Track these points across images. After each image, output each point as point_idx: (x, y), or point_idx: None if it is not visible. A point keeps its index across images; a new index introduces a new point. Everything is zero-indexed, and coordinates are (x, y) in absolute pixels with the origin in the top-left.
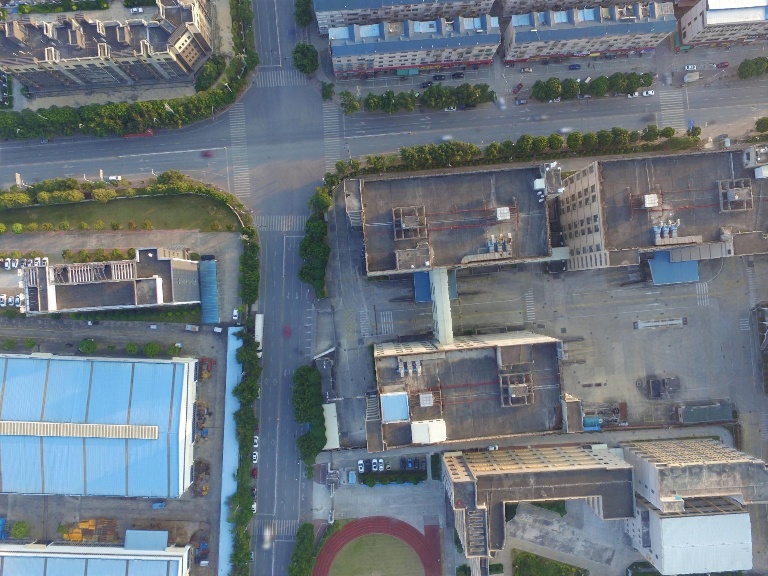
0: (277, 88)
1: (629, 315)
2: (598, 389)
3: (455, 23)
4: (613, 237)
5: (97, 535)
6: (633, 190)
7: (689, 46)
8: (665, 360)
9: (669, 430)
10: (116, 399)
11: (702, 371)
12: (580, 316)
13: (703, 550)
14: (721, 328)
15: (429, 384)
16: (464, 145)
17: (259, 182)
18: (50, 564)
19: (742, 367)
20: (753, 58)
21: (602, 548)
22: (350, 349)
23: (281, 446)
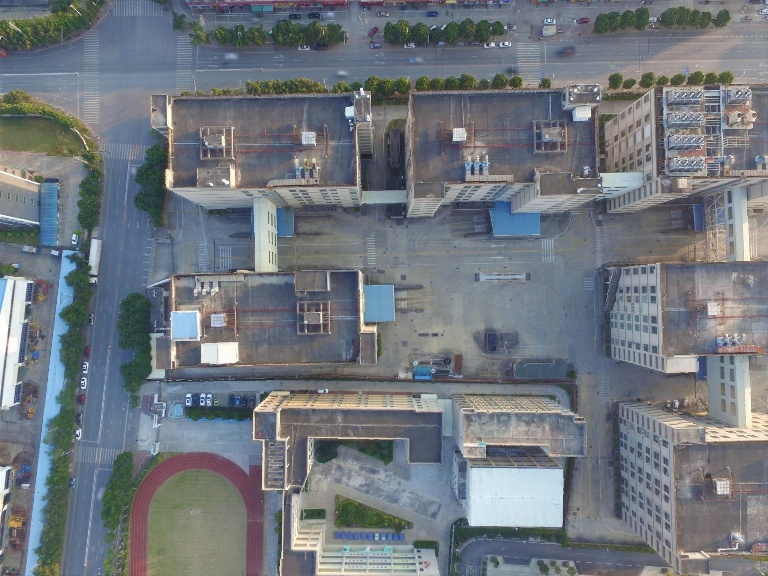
0: (133, 18)
1: (471, 266)
2: (434, 339)
3: None
4: (423, 171)
5: None
6: (447, 125)
7: None
8: (505, 314)
9: (505, 386)
10: None
11: (542, 328)
12: (421, 264)
13: (512, 503)
14: (565, 286)
15: (226, 306)
16: (309, 82)
17: (108, 109)
18: None
19: (584, 327)
20: (609, 13)
21: (428, 501)
22: None
23: (111, 374)
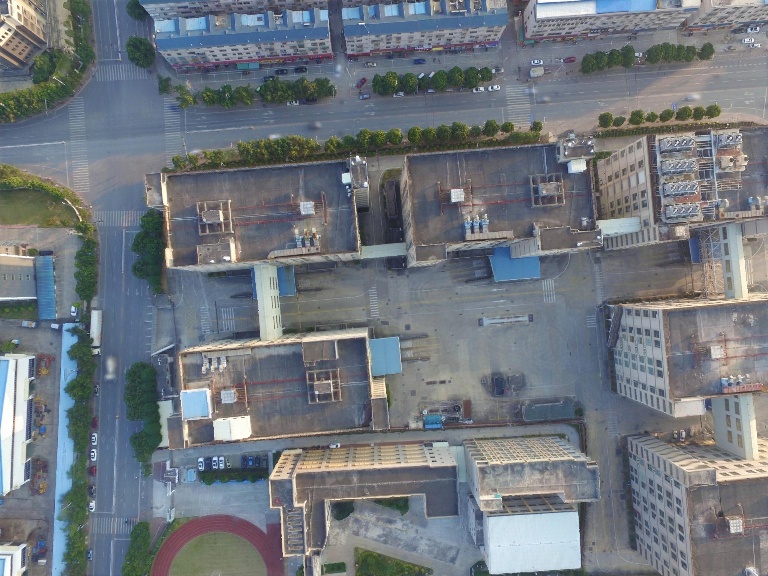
0: (117, 82)
1: (474, 312)
2: (442, 386)
3: (283, 16)
4: (424, 232)
5: None
6: (444, 185)
7: (533, 40)
8: (510, 357)
9: (514, 428)
10: None
11: (548, 368)
12: (424, 313)
13: (530, 549)
14: (567, 325)
15: (235, 381)
16: (300, 140)
17: (99, 177)
18: None
19: (589, 364)
20: (595, 53)
21: (446, 547)
22: (190, 346)
23: (121, 444)
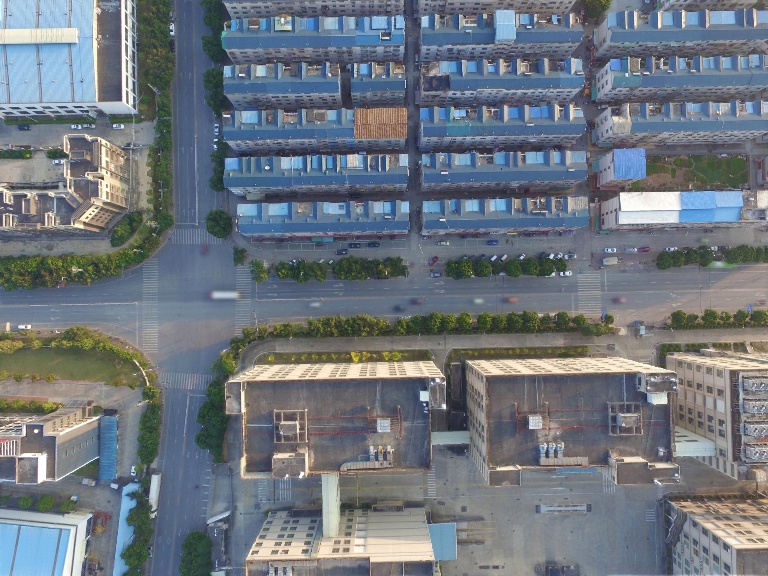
0: (192, 246)
1: (532, 498)
2: (495, 572)
3: (365, 206)
4: (497, 452)
5: None
6: (521, 406)
7: (608, 231)
8: (566, 546)
9: None
10: None
11: (604, 560)
12: (482, 495)
13: None
14: (626, 517)
15: None
16: (371, 321)
17: (167, 339)
18: None
19: (645, 559)
20: None
21: None
22: (246, 513)
23: None
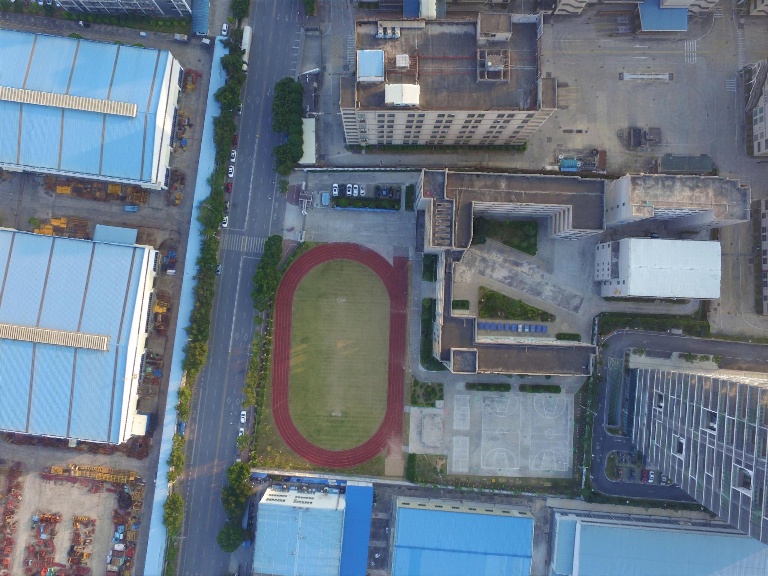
0: None
1: (615, 66)
2: (579, 136)
3: None
4: None
5: (68, 233)
6: None
7: None
8: (648, 113)
9: None
10: (98, 76)
11: (685, 127)
12: (566, 62)
13: (671, 273)
14: (707, 87)
15: (407, 53)
16: None
17: None
18: (18, 238)
19: (725, 127)
20: None
21: (571, 295)
22: (335, 74)
23: (258, 164)
